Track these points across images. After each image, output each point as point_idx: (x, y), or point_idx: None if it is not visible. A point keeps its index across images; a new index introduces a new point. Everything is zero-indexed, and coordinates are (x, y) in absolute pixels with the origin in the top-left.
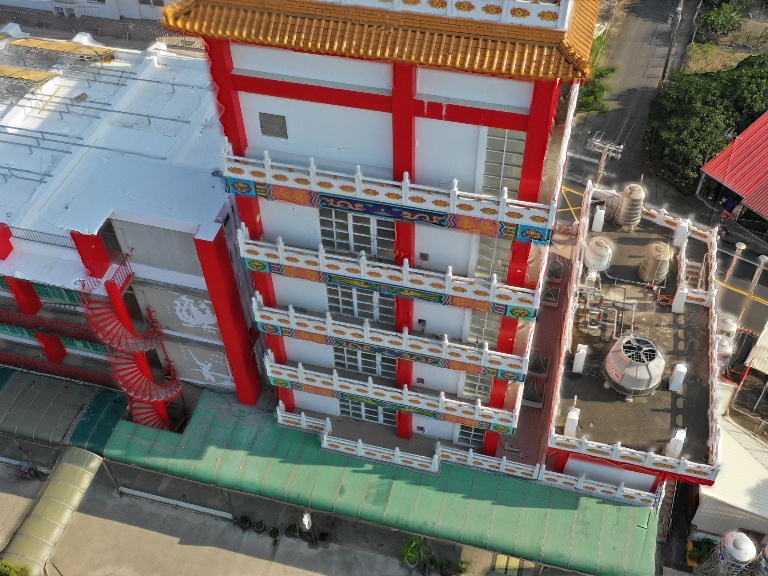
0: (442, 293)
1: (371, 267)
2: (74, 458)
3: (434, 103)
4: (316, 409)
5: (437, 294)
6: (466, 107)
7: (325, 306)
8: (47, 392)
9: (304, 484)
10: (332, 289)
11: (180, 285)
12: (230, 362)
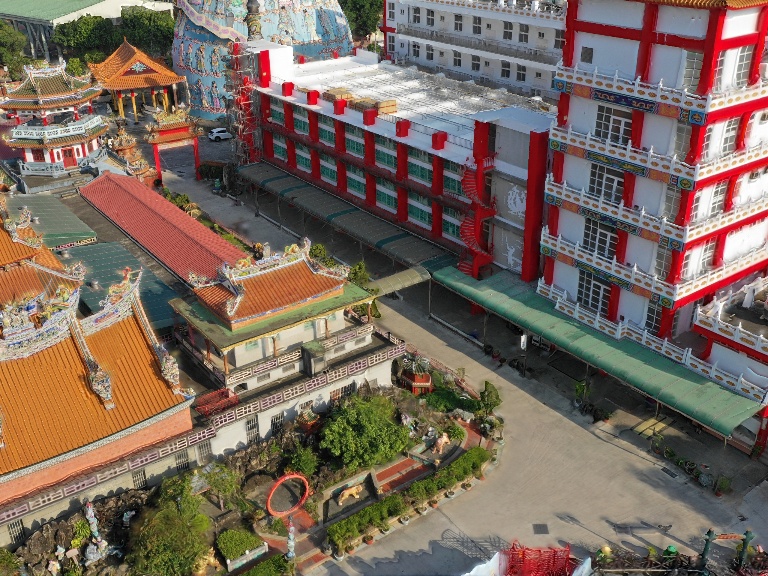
0: (645, 166)
1: (612, 146)
2: (417, 269)
3: (662, 34)
4: (562, 287)
5: (642, 167)
6: (676, 36)
7: (586, 190)
8: (422, 246)
9: (532, 318)
10: (593, 179)
11: (516, 176)
12: (524, 239)
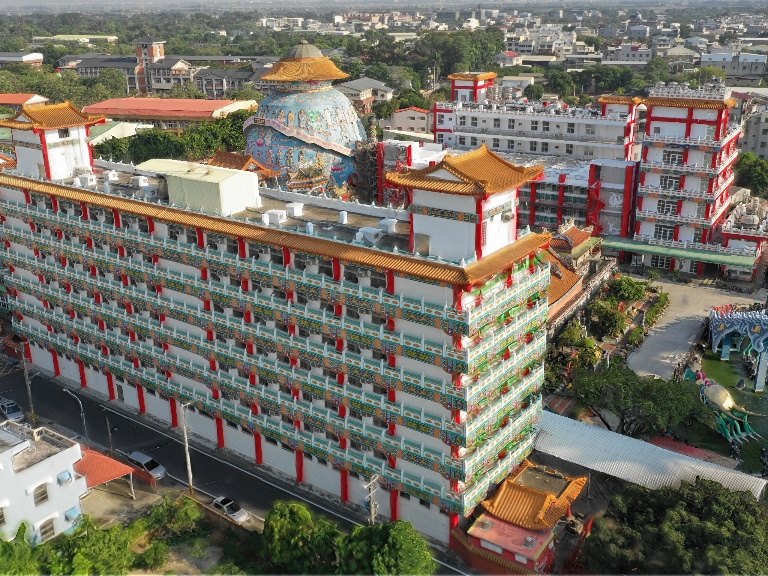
0: (694, 172)
1: (676, 166)
2: None
3: (696, 119)
4: None
5: (692, 172)
6: (703, 120)
7: None
8: None
9: None
10: (662, 182)
11: (615, 188)
12: (623, 217)
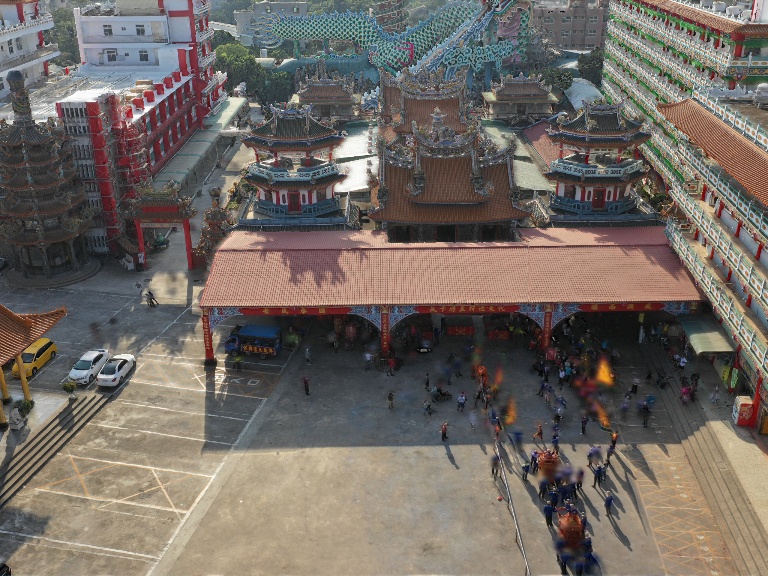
0: None
1: None
2: None
3: None
4: None
5: None
6: None
7: None
8: (199, 136)
9: None
10: None
11: None
12: None
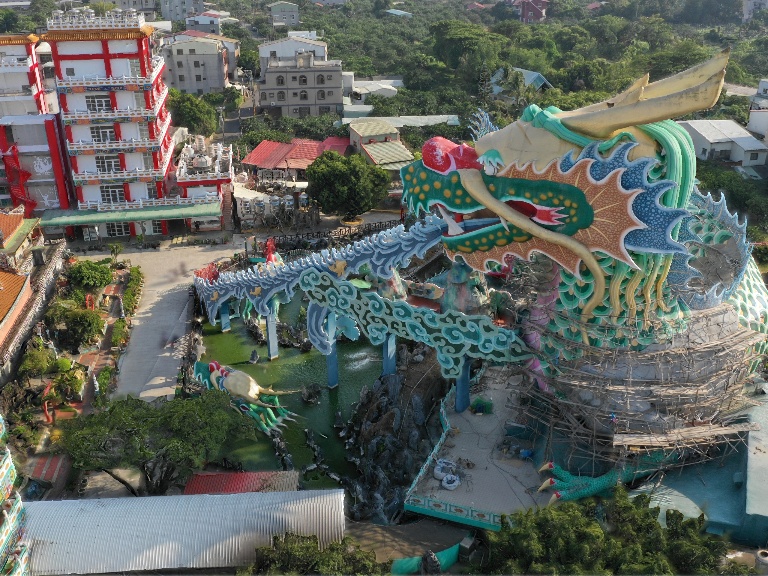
0: (128, 117)
1: (105, 113)
2: None
3: (114, 54)
4: None
5: (127, 118)
6: None
7: None
8: None
9: None
10: (93, 135)
11: (37, 151)
12: (57, 185)
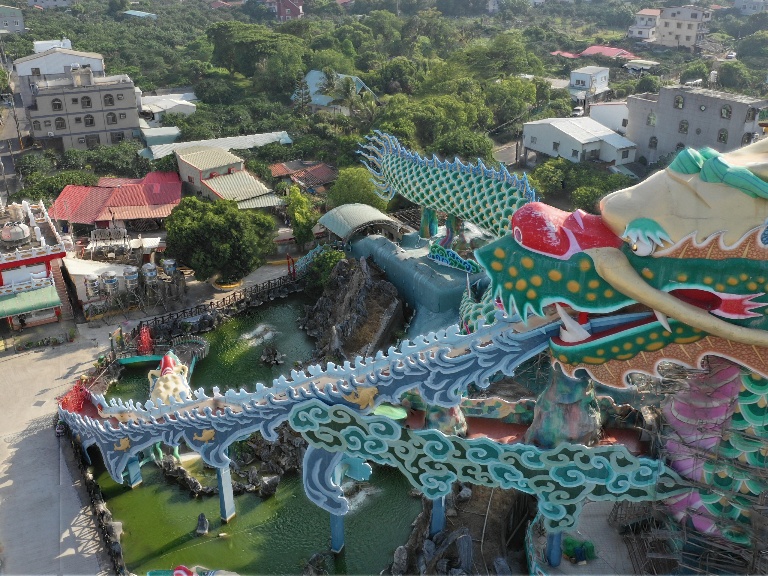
0: None
1: None
2: None
3: None
4: None
5: None
6: None
7: None
8: None
9: None
10: None
11: None
12: None
